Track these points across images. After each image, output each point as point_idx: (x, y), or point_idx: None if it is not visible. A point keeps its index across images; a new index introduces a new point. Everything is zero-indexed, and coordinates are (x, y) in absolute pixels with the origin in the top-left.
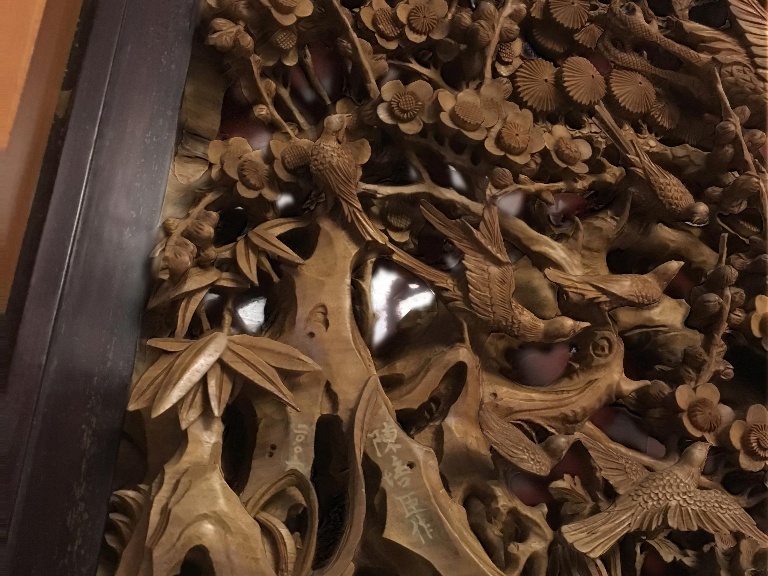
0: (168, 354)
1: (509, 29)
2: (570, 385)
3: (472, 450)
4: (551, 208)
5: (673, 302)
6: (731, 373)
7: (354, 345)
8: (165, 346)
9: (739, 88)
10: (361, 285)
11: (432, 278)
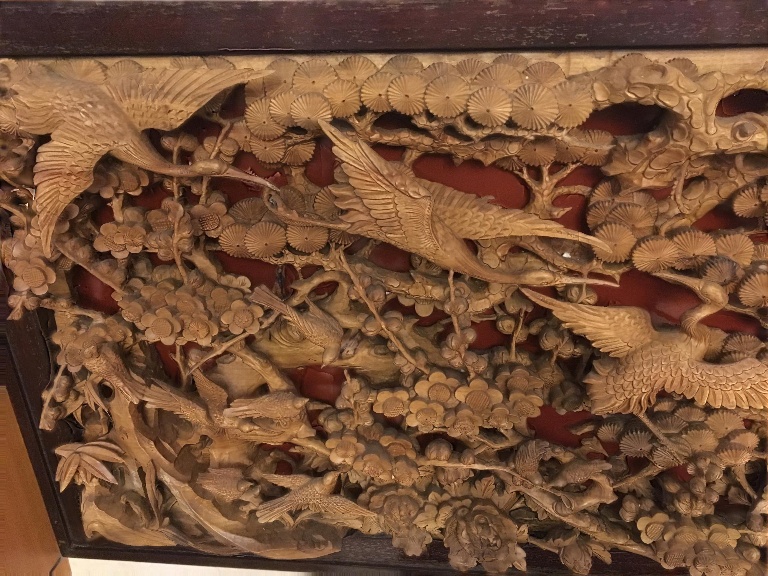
0: (63, 457)
1: (183, 248)
2: (275, 429)
3: (222, 465)
4: (288, 288)
5: (364, 353)
6: (369, 425)
7: (140, 446)
8: (61, 454)
9: None
10: (174, 360)
11: (171, 410)
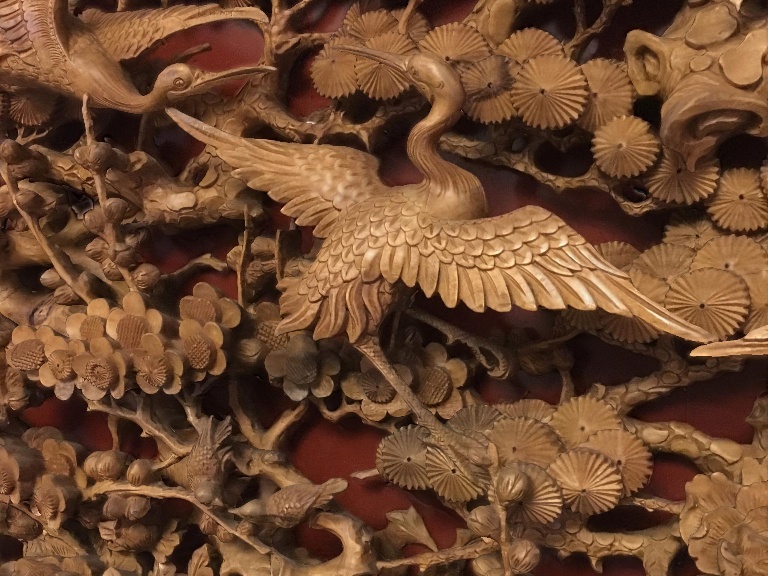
0: None
1: None
2: None
3: None
4: None
5: (58, 311)
6: (15, 404)
7: None
8: None
9: (27, 77)
10: None
11: None
